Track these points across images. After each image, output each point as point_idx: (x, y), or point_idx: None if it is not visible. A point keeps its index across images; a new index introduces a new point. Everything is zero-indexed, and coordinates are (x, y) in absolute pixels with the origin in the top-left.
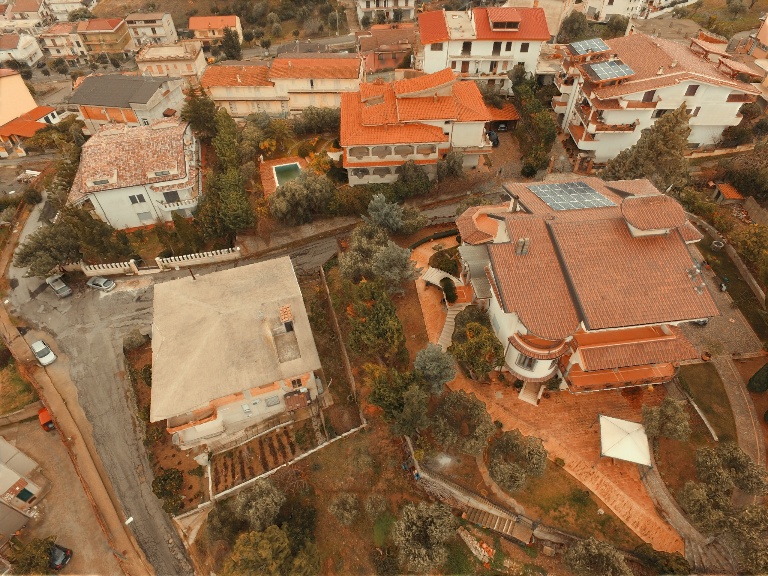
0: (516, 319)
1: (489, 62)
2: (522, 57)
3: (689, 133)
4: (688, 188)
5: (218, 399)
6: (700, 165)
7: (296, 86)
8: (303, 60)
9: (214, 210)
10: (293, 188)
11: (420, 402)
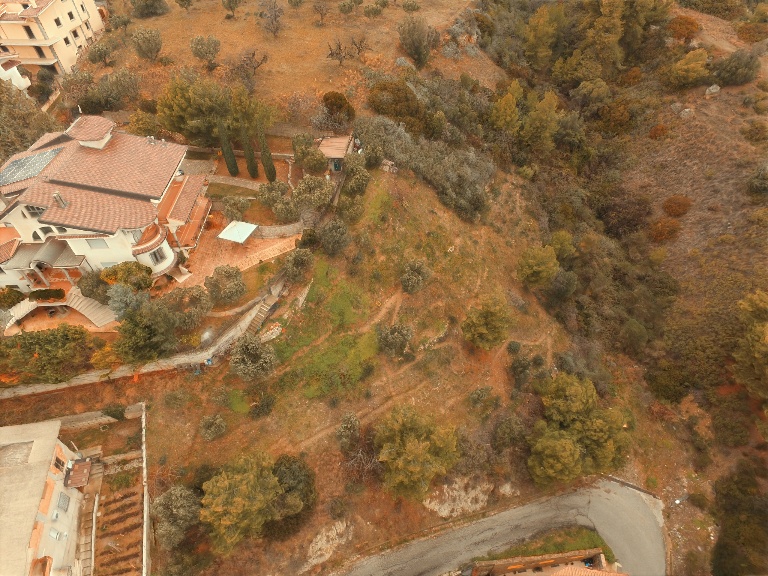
0: (122, 235)
1: None
2: None
3: None
4: None
5: None
6: None
7: None
8: None
9: None
10: None
11: None
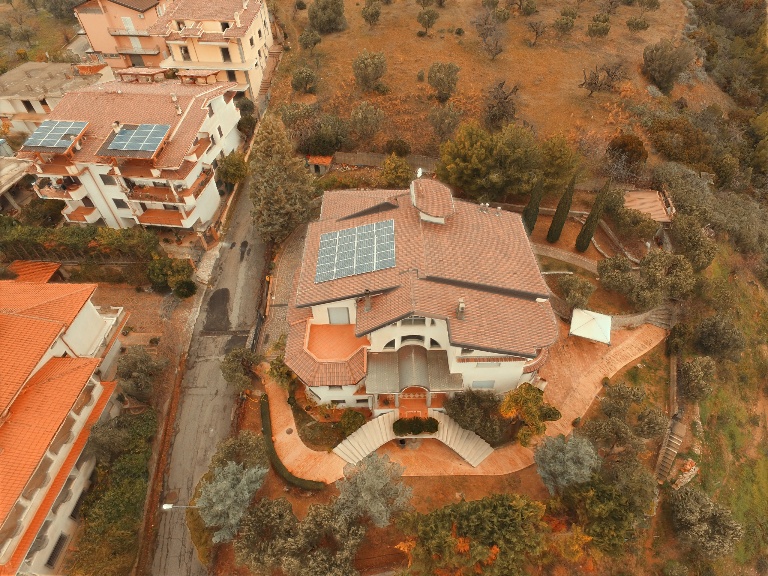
0: None
1: None
2: None
3: None
4: None
5: None
6: None
7: None
8: None
9: None
10: None
11: None
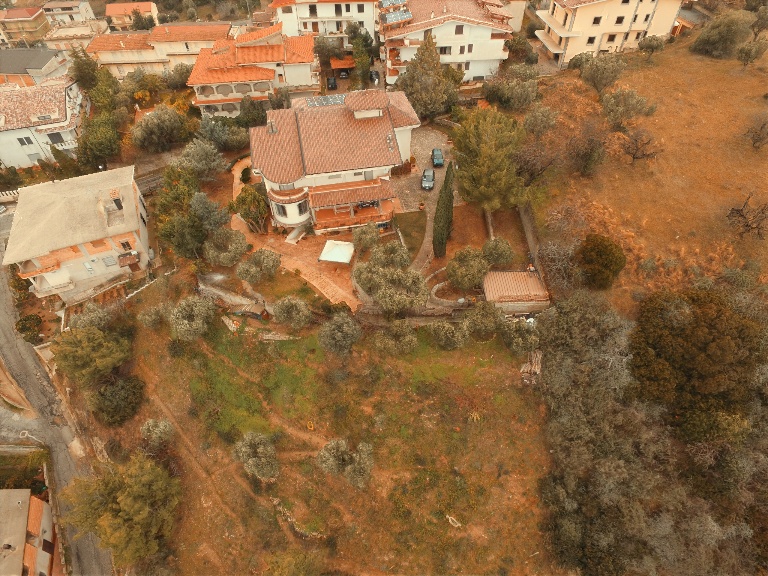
0: None
1: (334, 22)
2: (360, 17)
3: (438, 57)
4: (462, 107)
5: (60, 254)
6: (481, 92)
7: (173, 49)
8: (180, 27)
9: (86, 143)
10: (146, 119)
11: (184, 226)
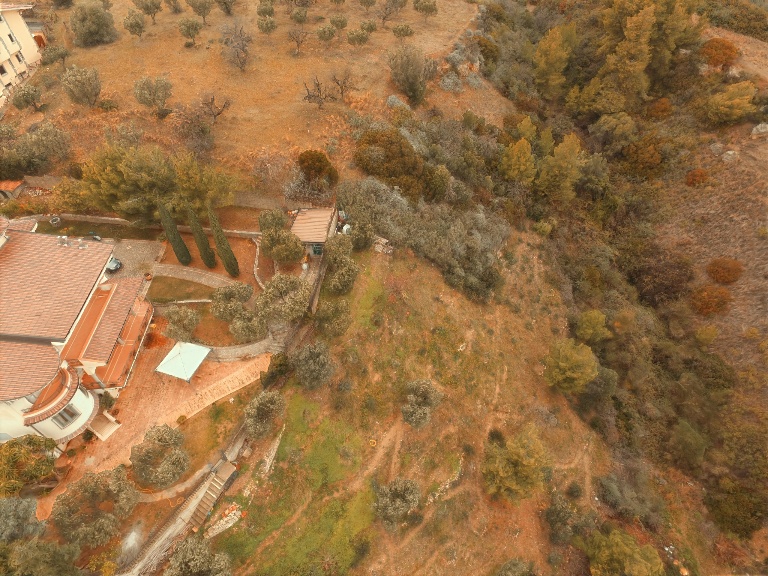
0: (4, 406)
1: None
2: None
3: None
4: None
5: None
6: None
7: None
8: None
9: None
10: None
11: (41, 549)
